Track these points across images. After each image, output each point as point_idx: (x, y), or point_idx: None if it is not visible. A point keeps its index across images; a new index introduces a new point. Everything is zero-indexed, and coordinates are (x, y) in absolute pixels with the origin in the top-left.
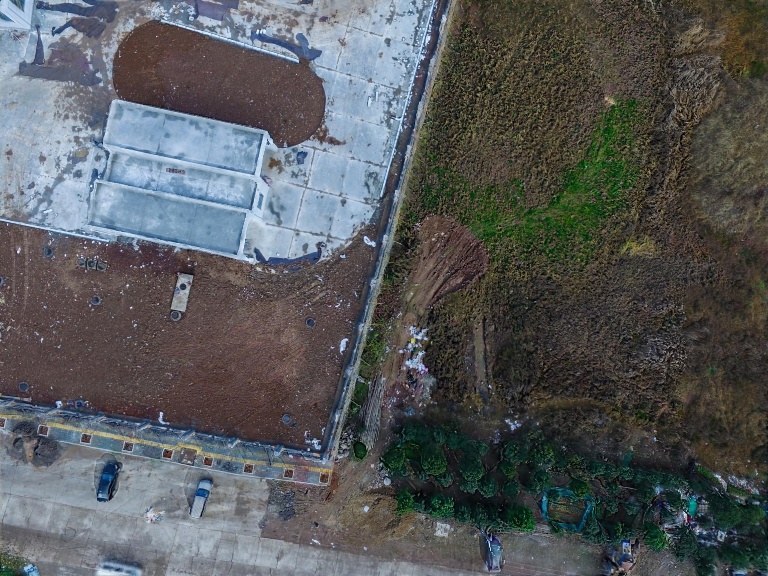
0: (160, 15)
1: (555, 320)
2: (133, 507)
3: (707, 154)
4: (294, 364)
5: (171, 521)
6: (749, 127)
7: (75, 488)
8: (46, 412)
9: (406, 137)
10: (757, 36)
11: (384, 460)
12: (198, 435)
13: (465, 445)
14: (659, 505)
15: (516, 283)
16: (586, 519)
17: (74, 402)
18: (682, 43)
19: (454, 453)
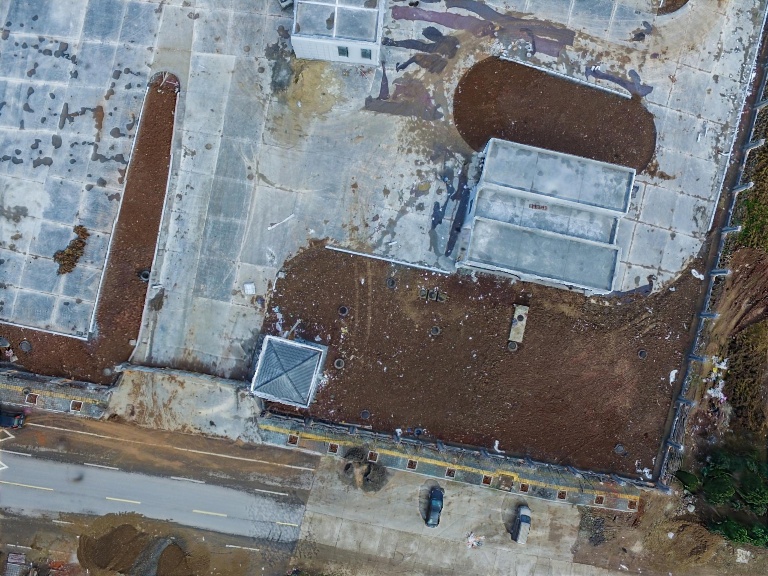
0: (499, 51)
1: None
2: (455, 532)
3: None
4: (627, 395)
5: (490, 546)
6: None
7: (402, 513)
8: (399, 441)
9: (733, 172)
10: None
11: None
12: None
13: None
14: None
15: None
16: None
17: (413, 430)
18: None
19: None
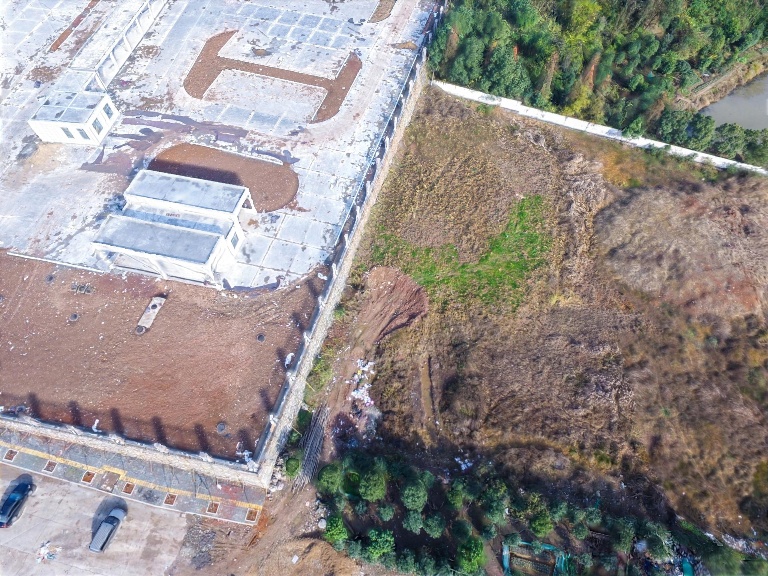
0: (191, 140)
1: (497, 359)
2: (28, 540)
3: (608, 232)
4: (239, 374)
5: (65, 561)
6: (636, 214)
7: None
8: None
9: None
10: (628, 166)
11: (321, 496)
12: (127, 444)
13: (407, 471)
14: (641, 559)
15: (456, 322)
16: (556, 574)
17: (16, 408)
18: (571, 167)
19: (395, 480)
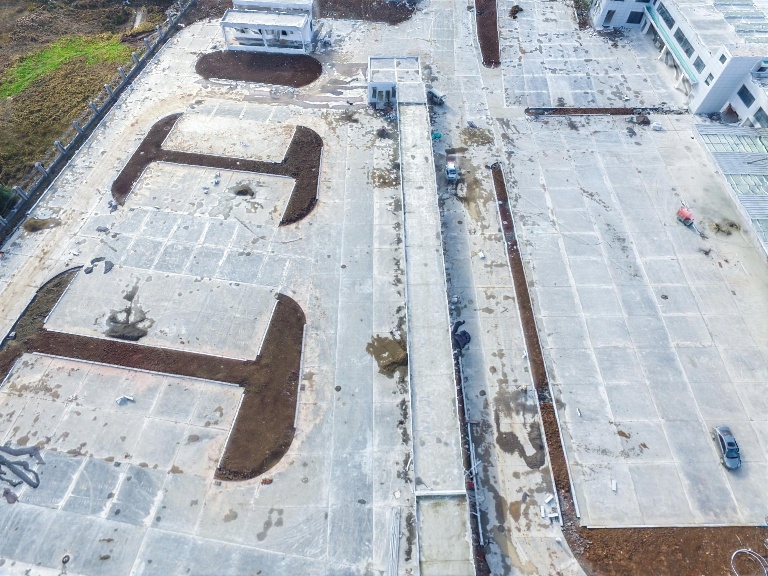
0: None
1: None
2: None
3: None
4: None
5: None
6: None
7: None
8: None
9: (149, 57)
10: None
11: None
12: None
13: None
14: None
15: None
16: None
17: None
18: None
19: None
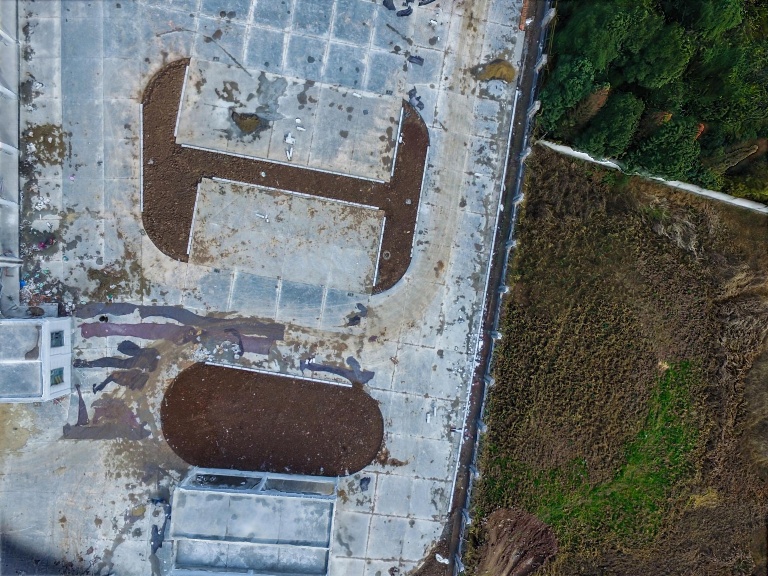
0: (204, 358)
1: None
2: None
3: (762, 401)
4: None
5: None
6: None
7: None
8: None
9: (469, 448)
10: None
11: None
12: None
13: None
14: None
15: (586, 559)
16: None
17: None
18: (728, 289)
19: None
